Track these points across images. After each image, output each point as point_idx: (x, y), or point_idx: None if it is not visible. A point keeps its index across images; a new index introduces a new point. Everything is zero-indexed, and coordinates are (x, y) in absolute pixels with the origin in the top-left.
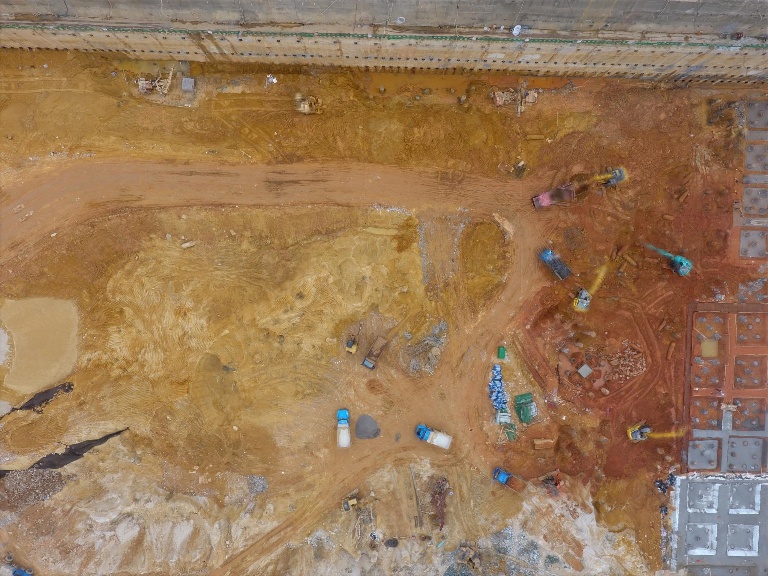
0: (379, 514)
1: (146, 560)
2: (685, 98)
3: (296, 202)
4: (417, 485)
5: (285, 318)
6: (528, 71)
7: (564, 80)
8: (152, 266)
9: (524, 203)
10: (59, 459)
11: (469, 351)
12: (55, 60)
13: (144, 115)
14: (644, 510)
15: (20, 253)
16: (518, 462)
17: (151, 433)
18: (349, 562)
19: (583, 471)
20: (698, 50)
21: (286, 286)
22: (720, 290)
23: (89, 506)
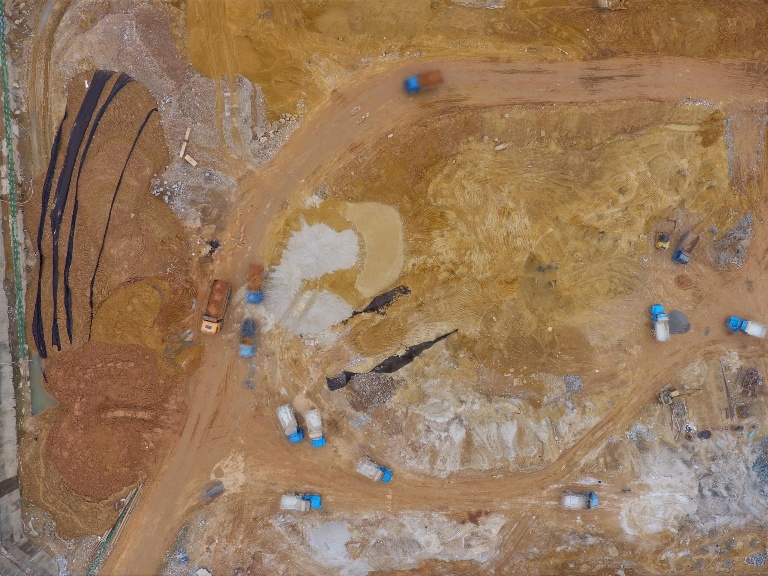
0: (691, 407)
1: (484, 457)
2: None
3: (610, 98)
4: (727, 377)
5: (608, 213)
6: None
7: None
8: (469, 169)
9: None
10: (397, 362)
11: None
12: None
13: (456, 16)
14: None
15: (360, 155)
16: None
17: (478, 334)
18: (668, 454)
19: None
20: None
21: (598, 185)
22: None
23: (421, 409)
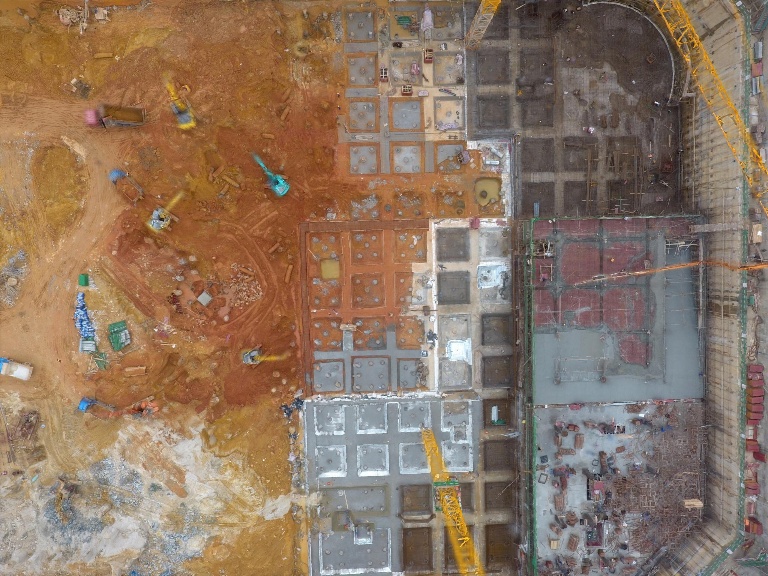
0: None
1: None
2: (267, 10)
3: None
4: (7, 420)
5: None
6: None
7: None
8: None
9: (94, 124)
10: None
11: (52, 280)
12: None
13: None
14: (264, 435)
15: None
16: (111, 391)
17: None
18: None
19: (198, 399)
20: None
21: None
22: (332, 209)
23: None
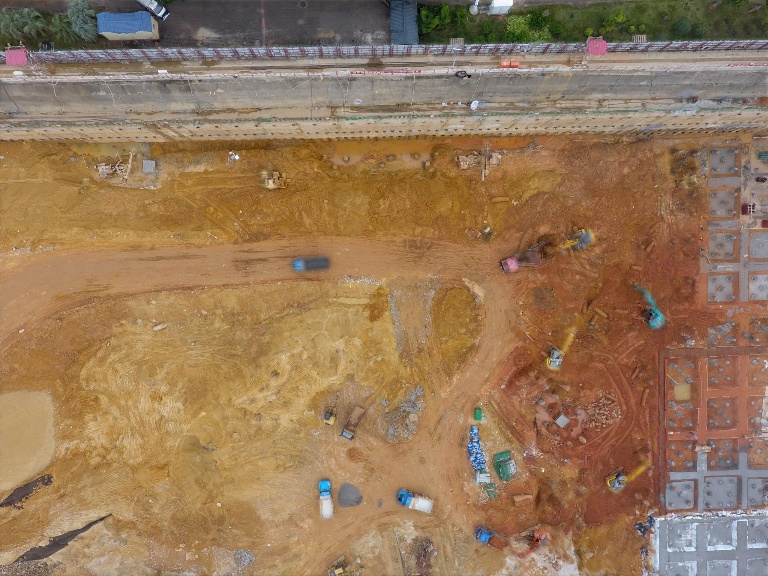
0: None
1: None
2: (647, 151)
3: (265, 279)
4: (402, 548)
5: (261, 397)
6: (490, 134)
7: (527, 139)
8: (125, 351)
9: (493, 266)
10: (43, 551)
11: (446, 414)
12: (11, 151)
13: (106, 200)
14: (625, 554)
15: None
16: (500, 519)
17: (134, 517)
18: None
19: (564, 520)
20: (655, 115)
21: (261, 362)
22: (690, 335)
23: None
